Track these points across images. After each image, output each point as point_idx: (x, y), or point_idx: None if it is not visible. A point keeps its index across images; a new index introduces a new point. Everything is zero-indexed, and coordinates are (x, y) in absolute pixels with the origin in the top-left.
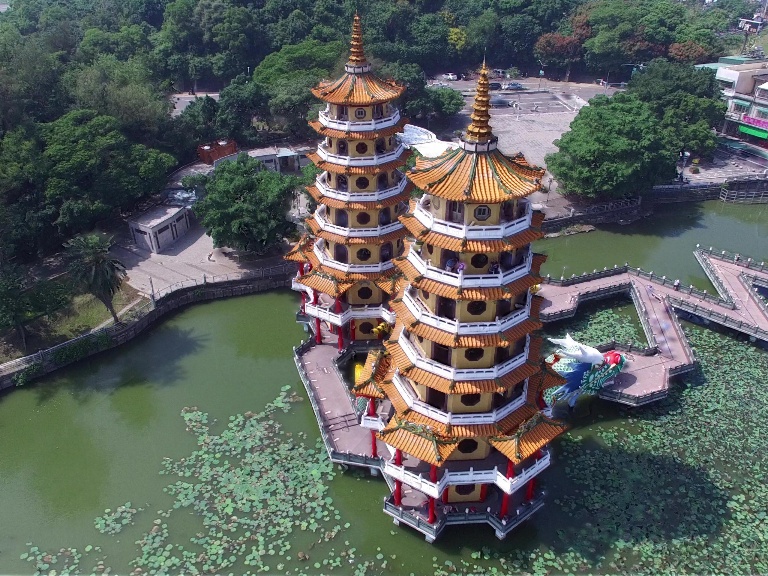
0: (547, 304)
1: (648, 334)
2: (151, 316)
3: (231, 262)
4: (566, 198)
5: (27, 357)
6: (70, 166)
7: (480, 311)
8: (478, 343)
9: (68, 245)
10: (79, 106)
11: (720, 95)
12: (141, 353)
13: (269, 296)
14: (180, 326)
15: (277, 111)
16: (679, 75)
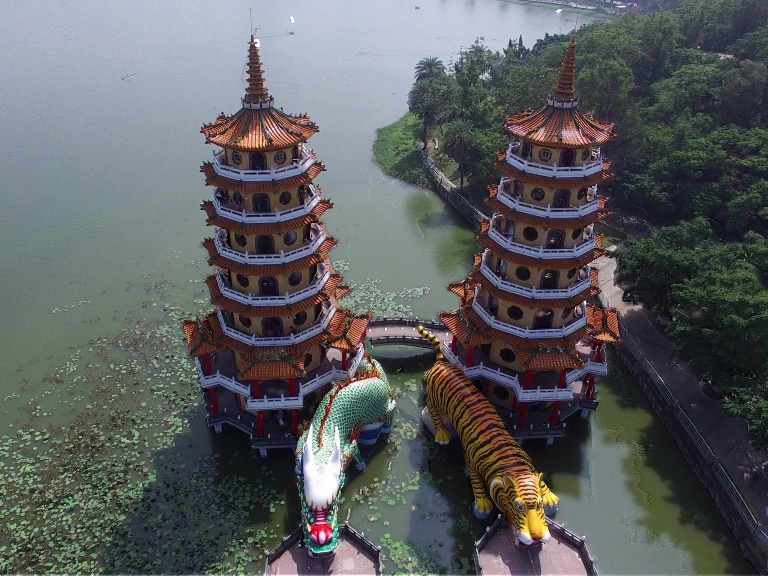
0: (519, 573)
1: None
2: None
3: None
4: None
5: None
6: (680, 155)
7: None
8: None
9: None
10: None
11: None
12: None
13: None
14: None
15: None
16: None
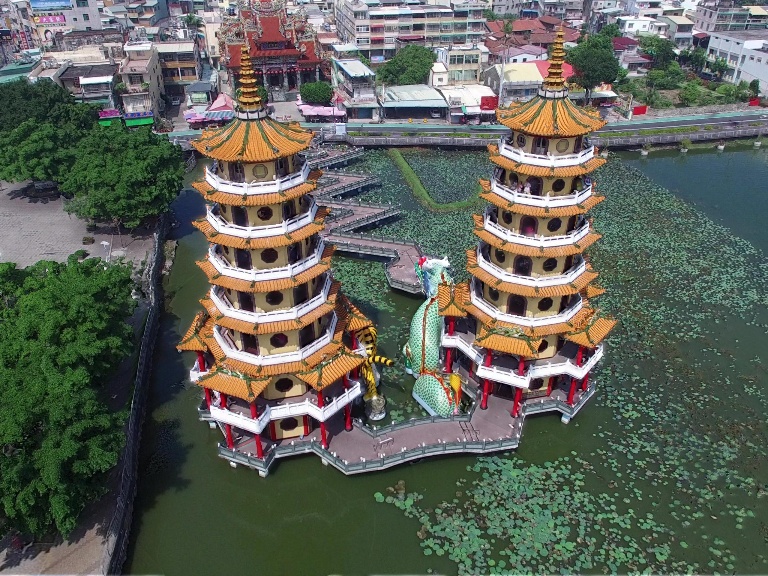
0: None
1: (374, 252)
2: None
3: (46, 555)
4: (117, 234)
5: None
6: None
7: None
8: None
9: None
10: None
11: (74, 99)
12: None
13: (148, 521)
14: None
15: None
16: (38, 90)
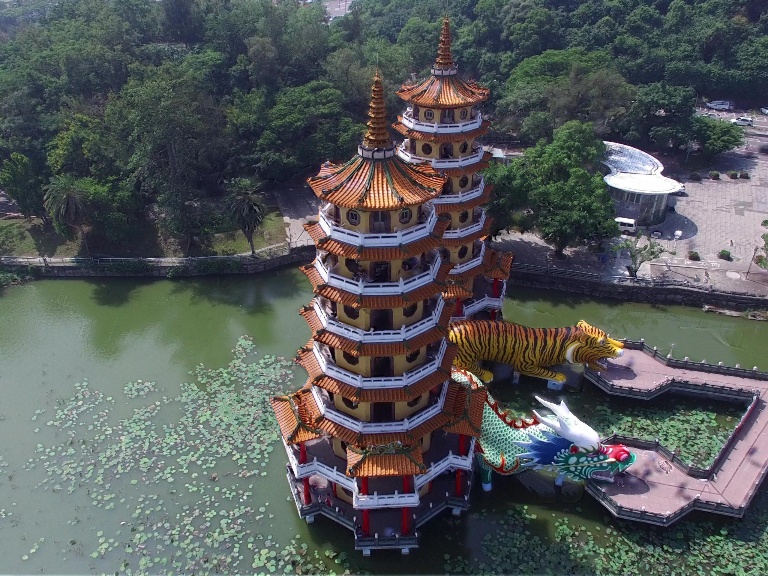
0: (628, 376)
1: None
2: (284, 259)
3: None
4: None
5: (180, 258)
6: (281, 124)
7: (356, 316)
8: (337, 344)
9: (227, 182)
10: (327, 78)
11: None
12: (257, 284)
13: None
14: (299, 274)
15: (502, 112)
16: None
